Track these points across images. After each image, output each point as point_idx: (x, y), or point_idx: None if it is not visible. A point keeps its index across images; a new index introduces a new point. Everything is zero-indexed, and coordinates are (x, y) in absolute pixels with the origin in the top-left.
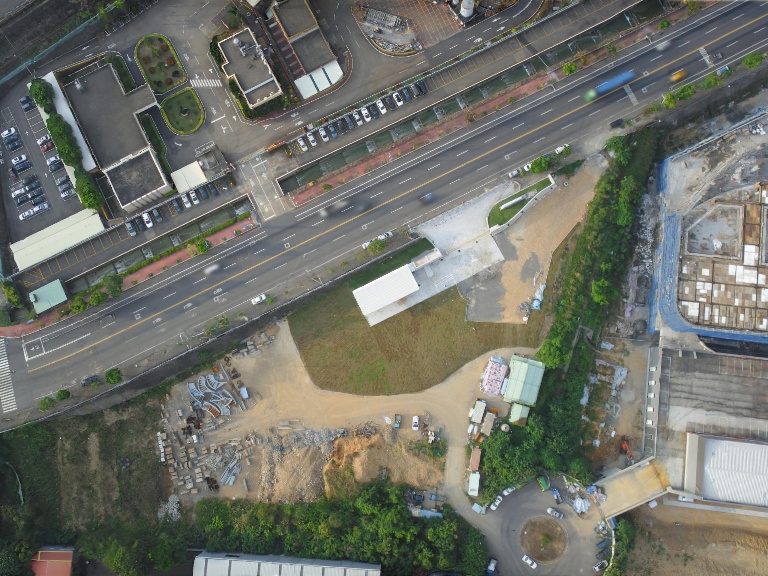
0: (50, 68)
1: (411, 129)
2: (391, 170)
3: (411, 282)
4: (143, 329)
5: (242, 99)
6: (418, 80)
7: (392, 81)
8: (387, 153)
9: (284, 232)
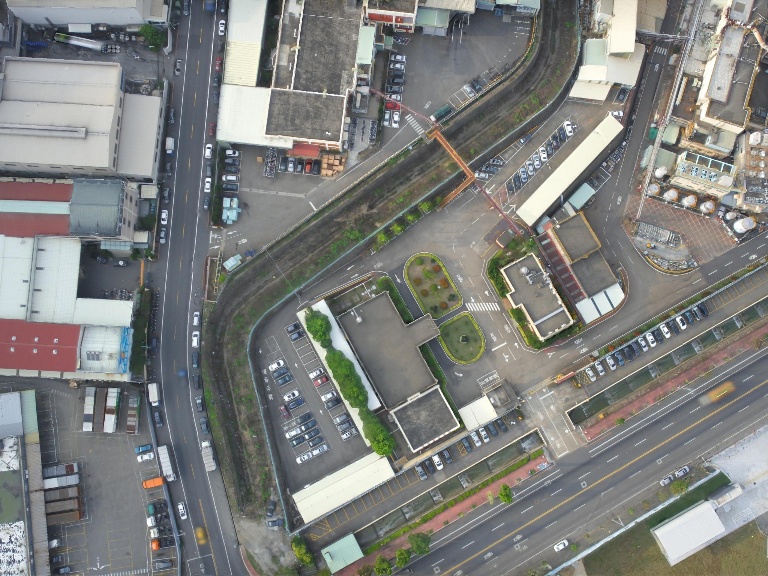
0: (315, 292)
1: (692, 351)
2: (680, 398)
3: (717, 523)
4: None
5: (524, 325)
6: (700, 302)
7: (671, 301)
8: (674, 380)
9: (579, 470)
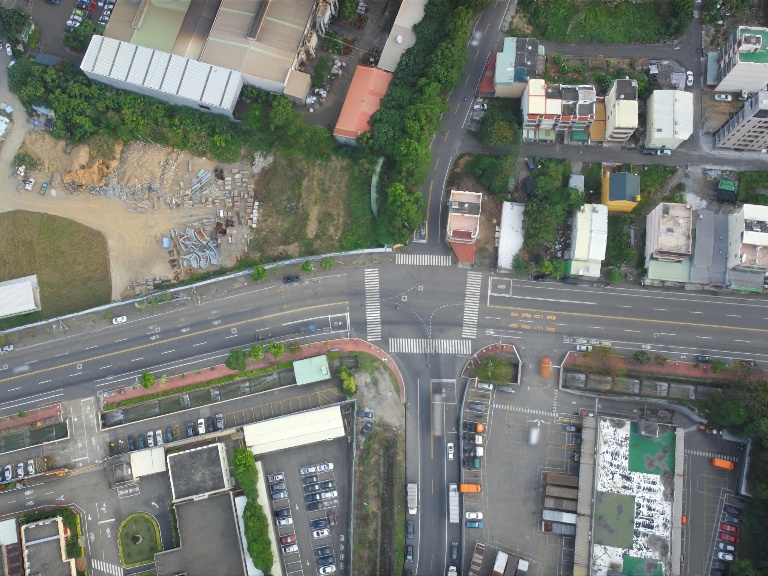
0: None
1: None
2: None
3: None
4: (232, 317)
5: None
6: None
7: None
8: None
9: (79, 381)
